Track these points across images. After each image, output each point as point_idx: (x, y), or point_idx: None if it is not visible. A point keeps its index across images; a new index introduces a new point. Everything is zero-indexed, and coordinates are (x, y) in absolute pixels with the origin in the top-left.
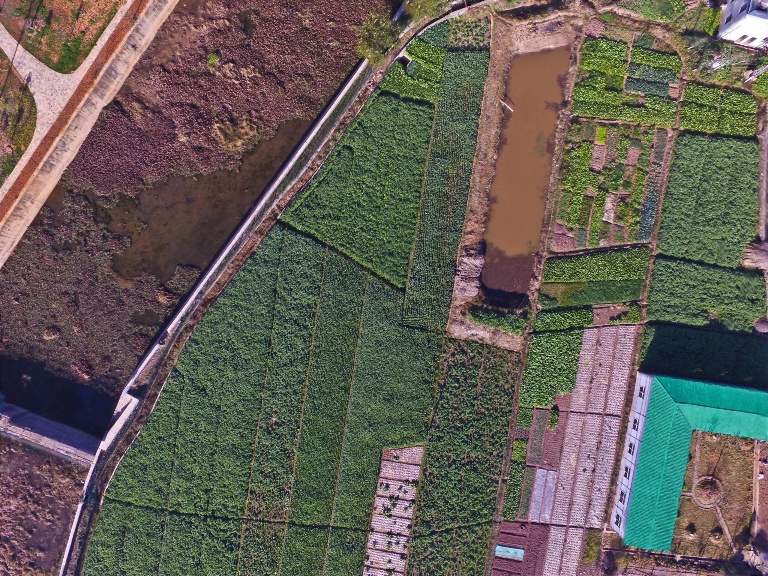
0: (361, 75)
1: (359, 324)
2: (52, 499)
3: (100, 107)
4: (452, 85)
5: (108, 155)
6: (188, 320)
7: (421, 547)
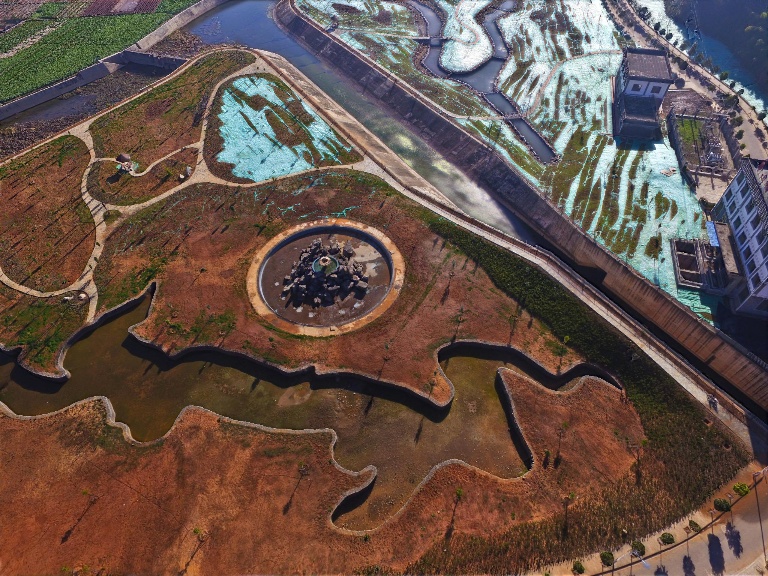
0: None
1: None
2: None
3: None
4: None
5: None
6: None
7: None
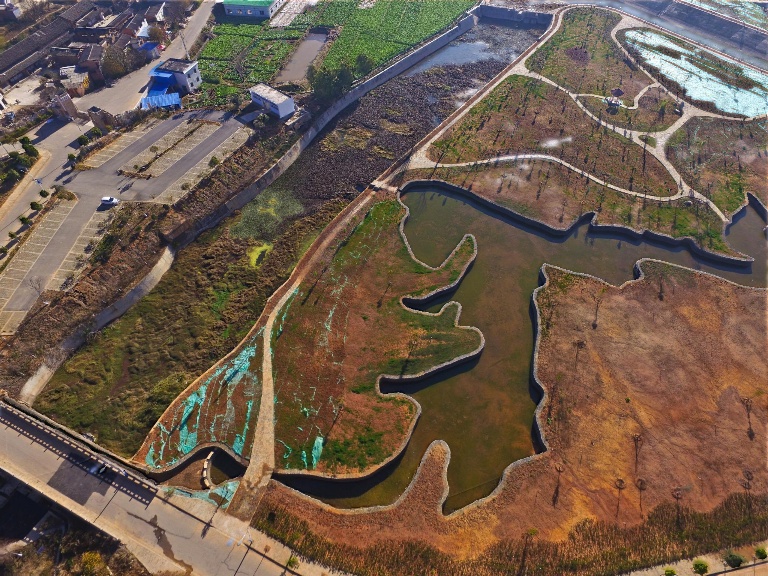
0: None
1: None
2: None
3: None
4: None
5: None
6: None
7: None
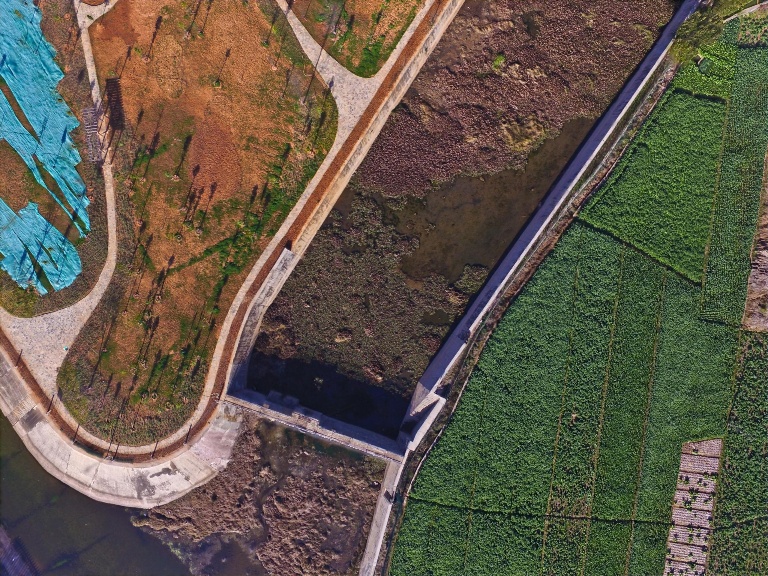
0: (653, 73)
1: (657, 319)
2: (345, 501)
3: (390, 110)
4: (745, 81)
5: (397, 157)
6: (487, 319)
7: (722, 539)
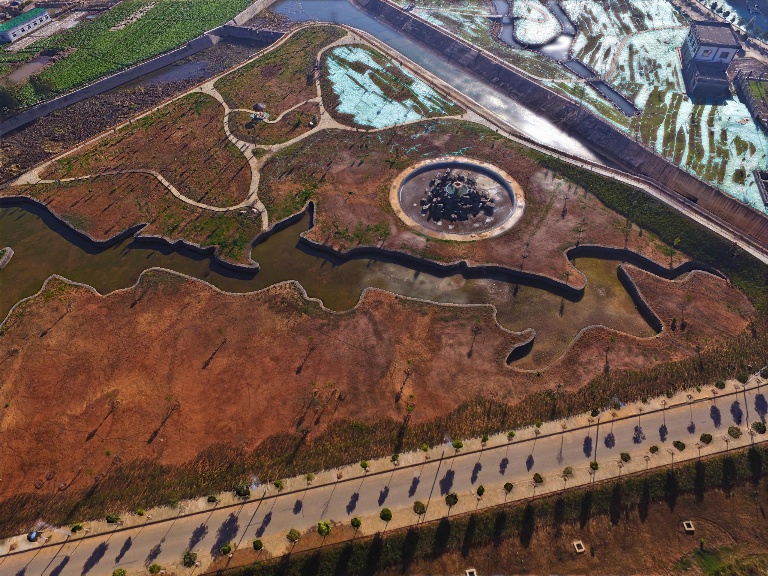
0: None
1: None
2: None
3: None
4: None
5: None
6: None
7: None
